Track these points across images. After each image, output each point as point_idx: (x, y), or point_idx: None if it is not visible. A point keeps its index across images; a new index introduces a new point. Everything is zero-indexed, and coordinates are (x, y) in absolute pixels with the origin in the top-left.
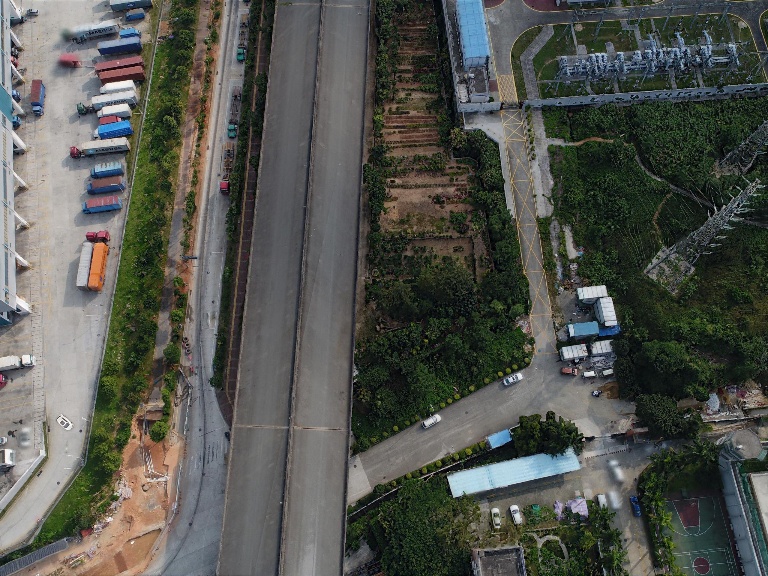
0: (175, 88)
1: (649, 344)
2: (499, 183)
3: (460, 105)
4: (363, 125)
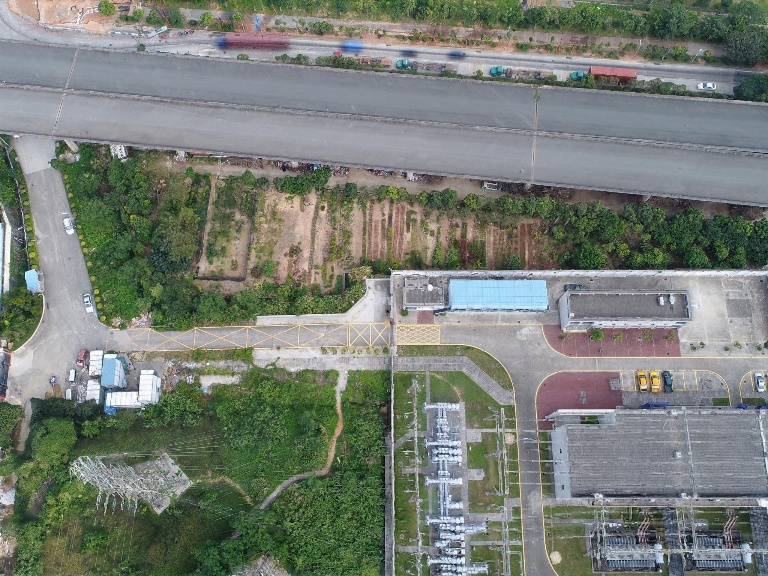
0: (447, 5)
1: (65, 424)
2: (293, 306)
3: (392, 271)
4: (370, 165)
